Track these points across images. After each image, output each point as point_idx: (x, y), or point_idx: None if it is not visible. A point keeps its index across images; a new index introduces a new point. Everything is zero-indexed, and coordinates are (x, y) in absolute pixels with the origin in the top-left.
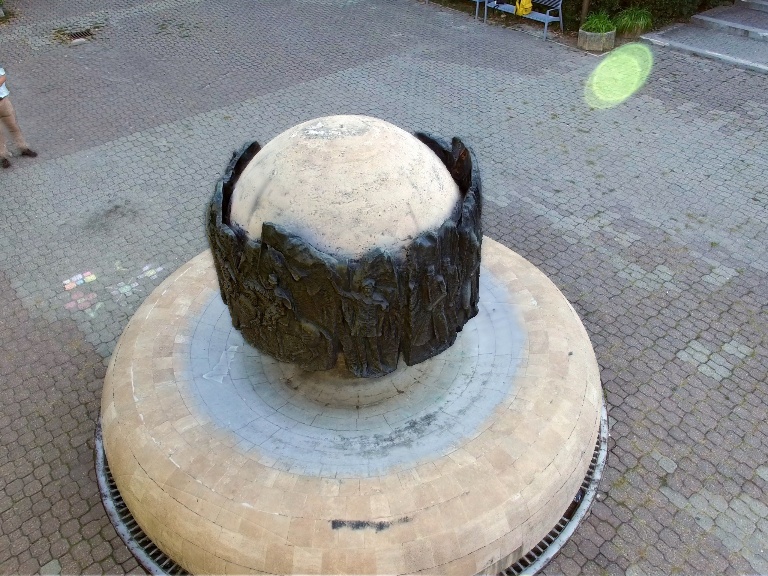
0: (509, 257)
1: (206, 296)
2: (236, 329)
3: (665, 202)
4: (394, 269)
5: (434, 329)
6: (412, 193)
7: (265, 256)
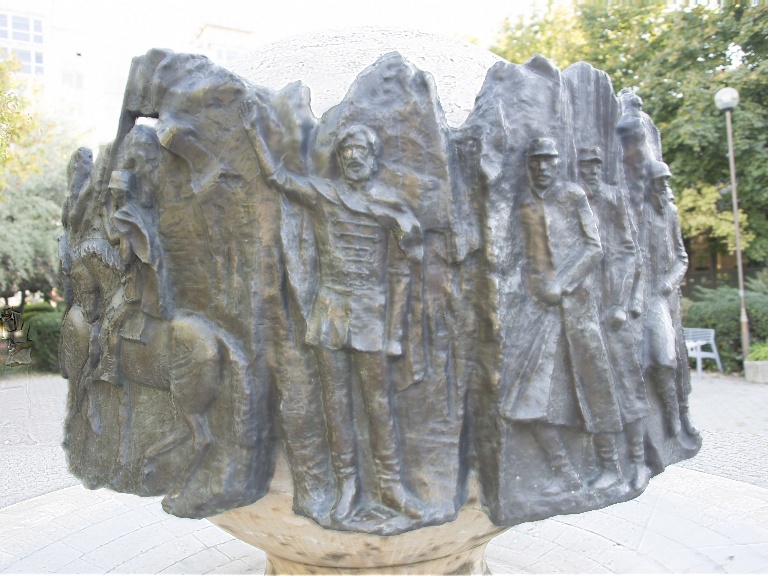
0: (735, 481)
1: (102, 509)
2: None
3: None
4: (435, 114)
5: (573, 386)
6: (492, 61)
7: (121, 143)
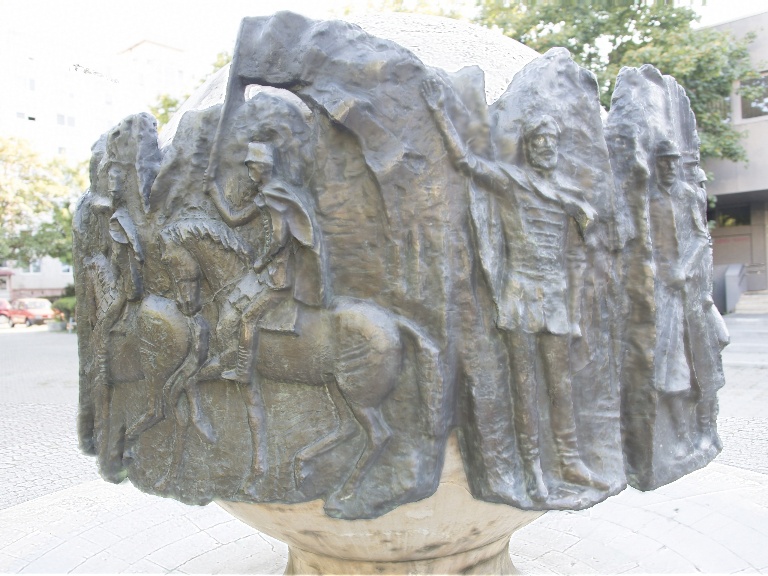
0: None
1: (31, 544)
2: (108, 479)
3: (764, 453)
4: None
5: (690, 361)
6: None
7: (237, 112)
